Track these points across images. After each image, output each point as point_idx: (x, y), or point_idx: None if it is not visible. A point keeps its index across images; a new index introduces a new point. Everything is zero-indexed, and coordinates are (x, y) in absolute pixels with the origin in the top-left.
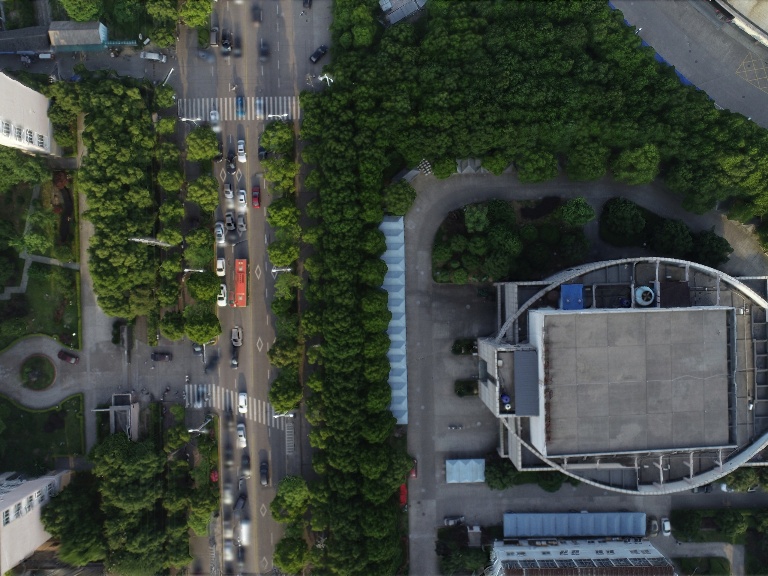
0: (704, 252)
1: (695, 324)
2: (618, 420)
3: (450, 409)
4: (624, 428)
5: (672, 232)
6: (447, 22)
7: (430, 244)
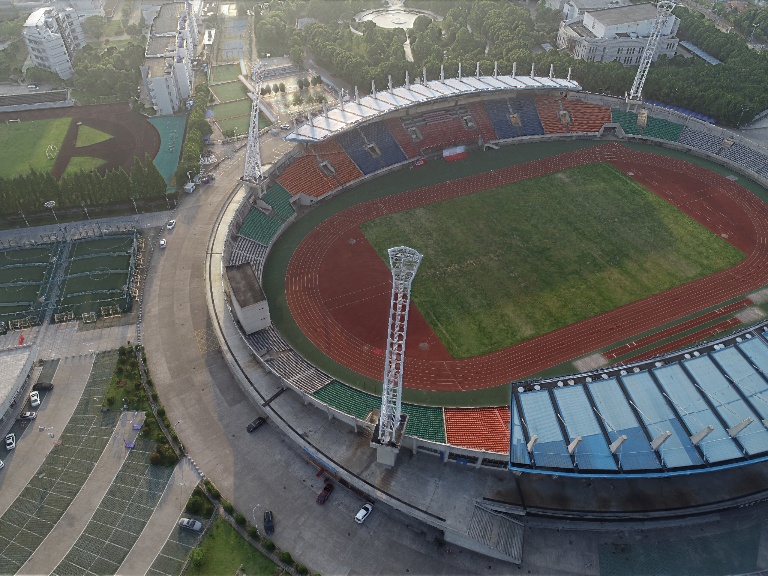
0: None
1: None
2: None
3: None
4: None
5: None
6: None
7: None
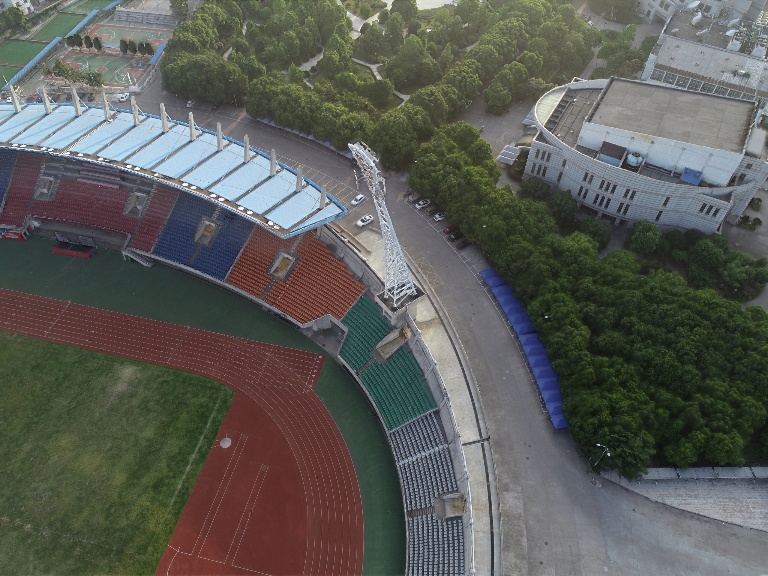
0: (547, 187)
1: (616, 125)
2: (693, 104)
3: (766, 200)
4: (690, 101)
5: (571, 201)
6: (736, 420)
7: (765, 293)
